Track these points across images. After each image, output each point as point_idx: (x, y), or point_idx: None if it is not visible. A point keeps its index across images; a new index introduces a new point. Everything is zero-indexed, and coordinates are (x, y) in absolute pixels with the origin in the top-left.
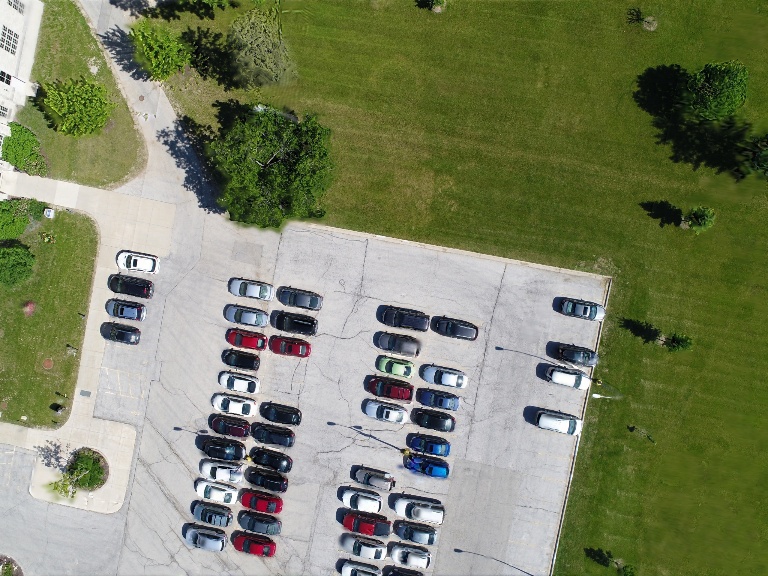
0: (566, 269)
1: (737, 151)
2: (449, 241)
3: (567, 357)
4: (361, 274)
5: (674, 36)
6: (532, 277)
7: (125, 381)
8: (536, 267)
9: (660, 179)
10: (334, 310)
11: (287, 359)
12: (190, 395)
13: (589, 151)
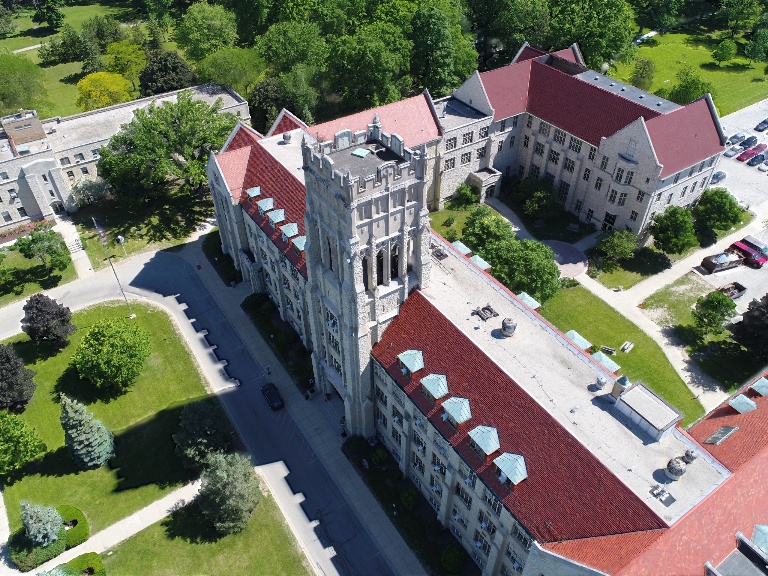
0: (767, 98)
1: (744, 67)
2: (736, 109)
3: None
4: (735, 127)
5: (692, 61)
6: (765, 104)
7: (743, 190)
8: (761, 102)
9: (744, 77)
10: (747, 137)
11: (763, 154)
12: (764, 180)
13: None
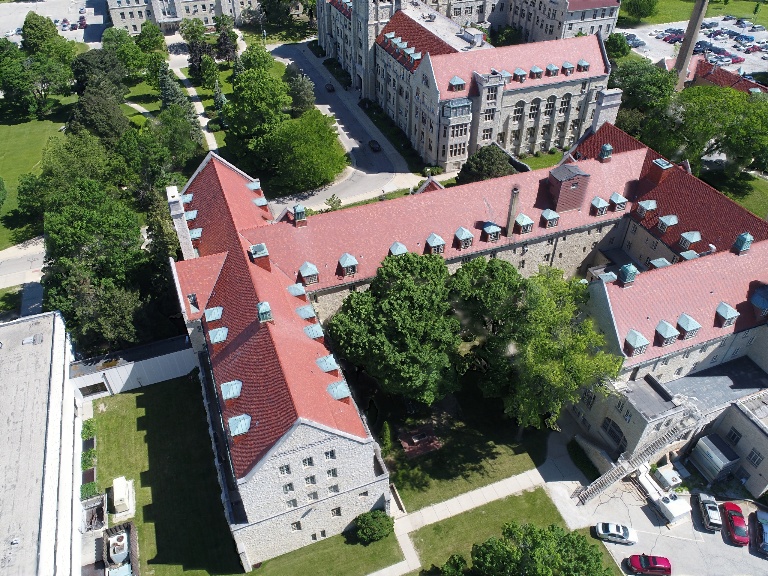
0: (716, 17)
1: None
2: None
3: (741, 21)
4: None
5: None
6: None
7: None
8: None
9: None
10: None
11: None
12: None
13: (689, 7)
